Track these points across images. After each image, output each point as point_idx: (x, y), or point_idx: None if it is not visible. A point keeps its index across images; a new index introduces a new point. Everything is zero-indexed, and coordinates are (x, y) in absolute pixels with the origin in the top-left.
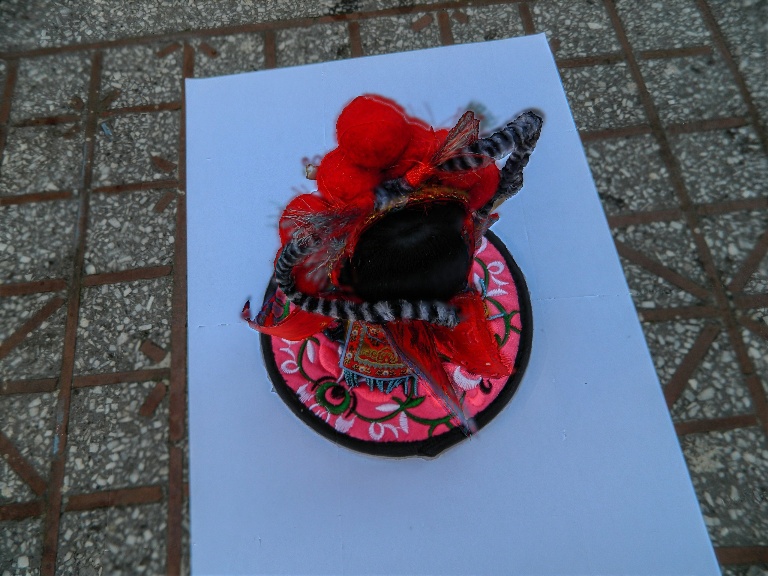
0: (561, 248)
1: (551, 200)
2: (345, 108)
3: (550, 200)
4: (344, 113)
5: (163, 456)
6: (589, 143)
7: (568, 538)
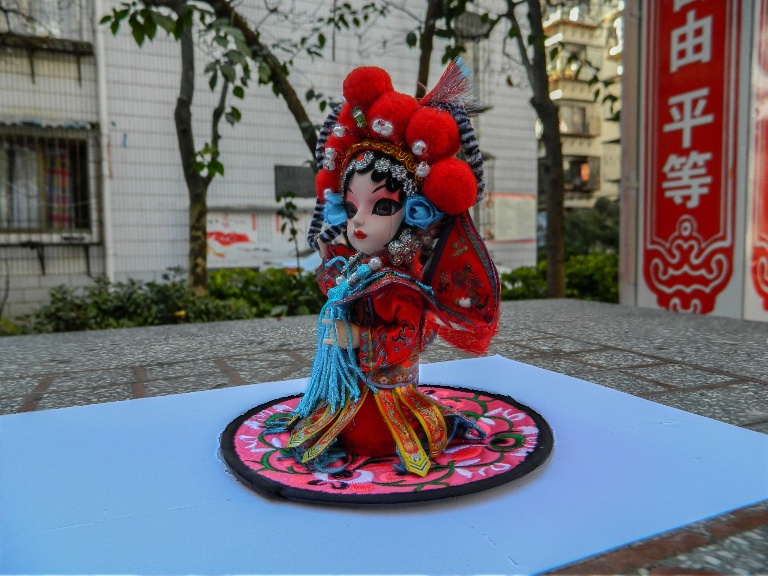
0: (273, 394)
1: (218, 401)
2: (364, 69)
3: (218, 401)
4: (370, 68)
5: (739, 542)
6: (148, 396)
7: (511, 378)
